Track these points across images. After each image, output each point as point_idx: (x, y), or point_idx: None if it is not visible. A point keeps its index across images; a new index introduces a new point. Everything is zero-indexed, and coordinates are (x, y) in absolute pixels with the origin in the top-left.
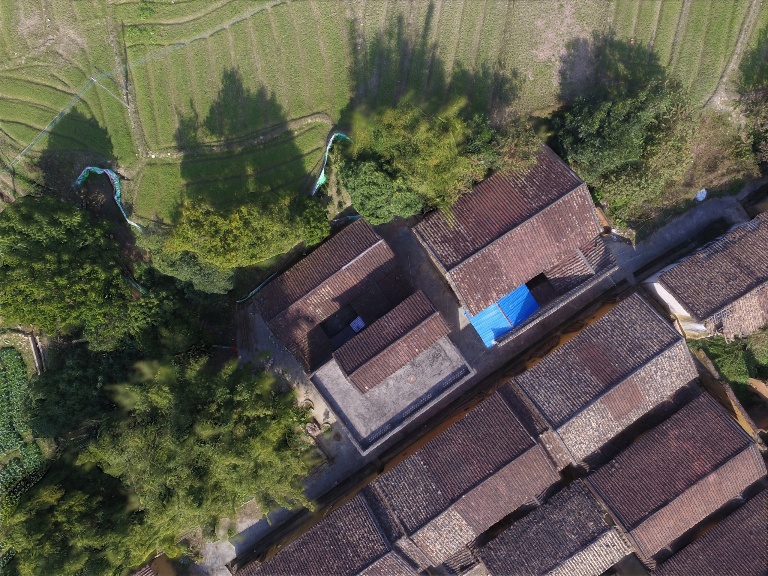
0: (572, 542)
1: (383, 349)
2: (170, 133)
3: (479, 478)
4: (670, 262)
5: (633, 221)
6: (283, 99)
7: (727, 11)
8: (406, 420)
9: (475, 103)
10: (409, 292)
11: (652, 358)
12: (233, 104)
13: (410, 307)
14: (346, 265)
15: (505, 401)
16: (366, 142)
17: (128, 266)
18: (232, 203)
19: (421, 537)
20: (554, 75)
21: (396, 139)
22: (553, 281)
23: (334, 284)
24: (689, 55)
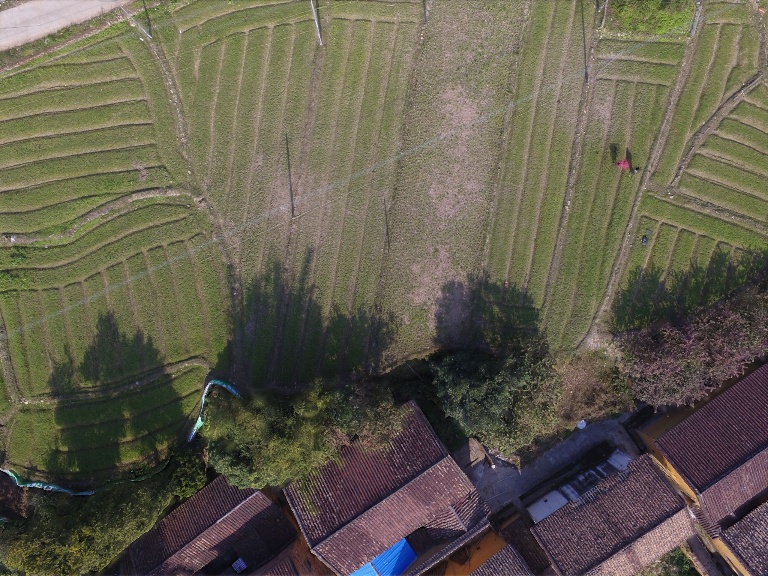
0: None
1: None
2: (43, 380)
3: None
4: (555, 487)
5: None
6: (159, 343)
7: (597, 255)
8: None
9: (352, 348)
10: (290, 534)
11: None
12: (108, 350)
13: None
14: (221, 518)
15: None
16: (223, 431)
17: (3, 509)
18: (108, 448)
19: None
20: (430, 319)
21: (249, 436)
22: (429, 531)
23: (210, 536)
24: (562, 297)
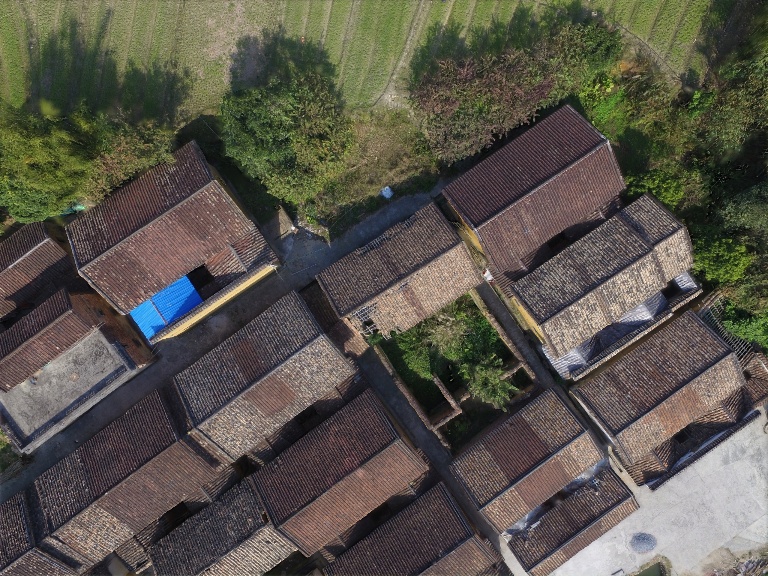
0: (230, 539)
1: (17, 347)
2: None
3: (123, 475)
4: None
5: (323, 219)
6: None
7: (395, 9)
8: (63, 418)
9: (146, 102)
10: (89, 290)
11: (292, 355)
12: None
13: (51, 305)
14: (13, 264)
15: (161, 398)
16: None
17: None
18: None
19: (67, 534)
20: (225, 74)
21: None
22: (217, 279)
23: (4, 283)
24: (359, 53)
